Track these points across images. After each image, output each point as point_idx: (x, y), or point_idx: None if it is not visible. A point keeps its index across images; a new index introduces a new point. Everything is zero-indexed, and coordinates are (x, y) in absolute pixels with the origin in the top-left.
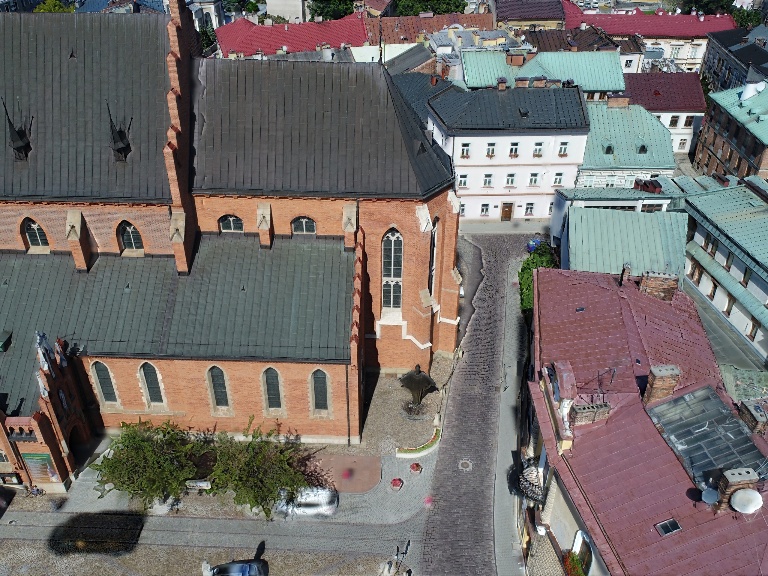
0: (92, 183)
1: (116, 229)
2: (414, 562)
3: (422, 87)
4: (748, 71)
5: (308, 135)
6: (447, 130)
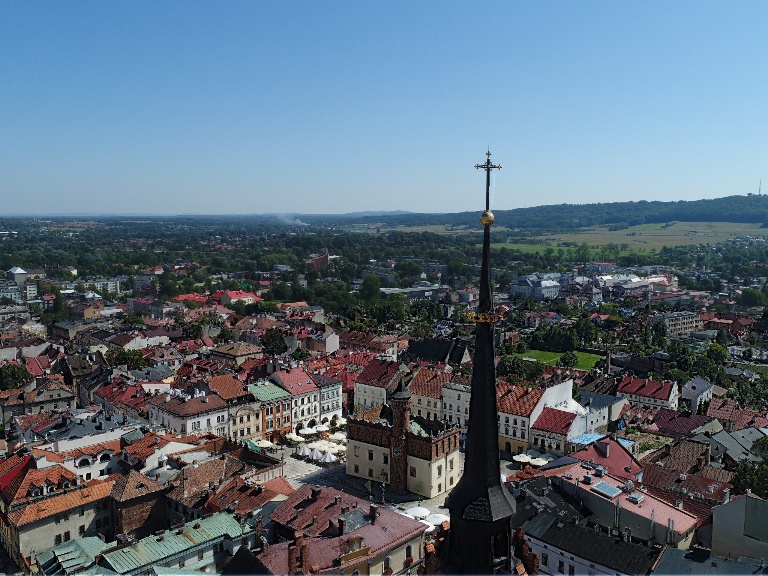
0: None
1: None
2: None
3: None
4: None
5: None
6: None
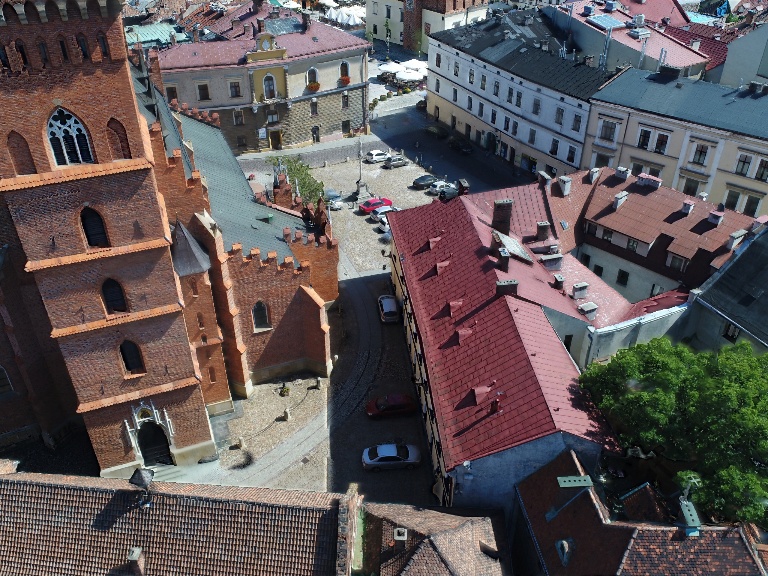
0: None
1: None
2: None
3: None
4: None
5: None
6: None
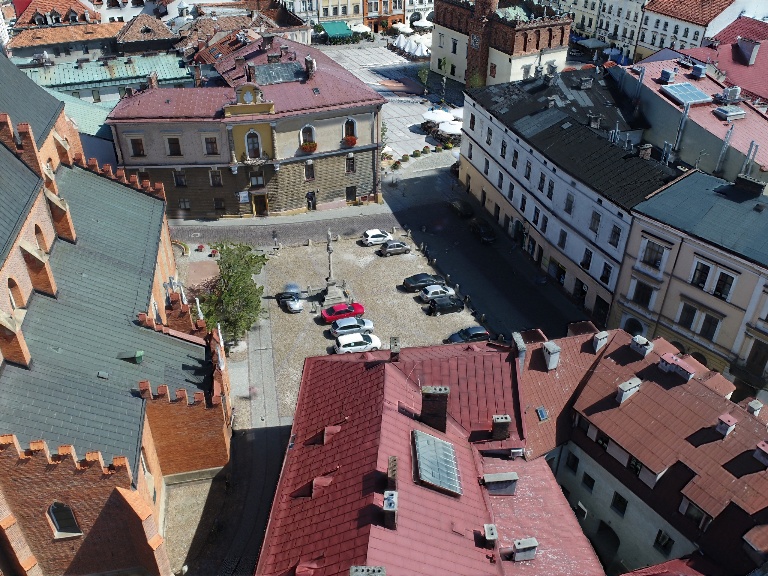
0: (8, 206)
1: (35, 240)
2: (268, 248)
3: None
4: None
5: (1, 97)
6: None
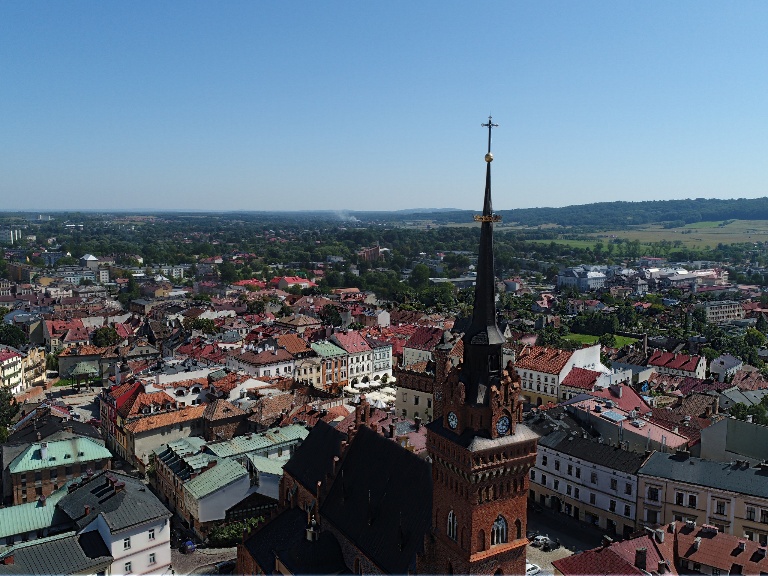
0: None
1: None
2: None
3: (11, 571)
4: (3, 451)
5: None
6: (170, 515)
